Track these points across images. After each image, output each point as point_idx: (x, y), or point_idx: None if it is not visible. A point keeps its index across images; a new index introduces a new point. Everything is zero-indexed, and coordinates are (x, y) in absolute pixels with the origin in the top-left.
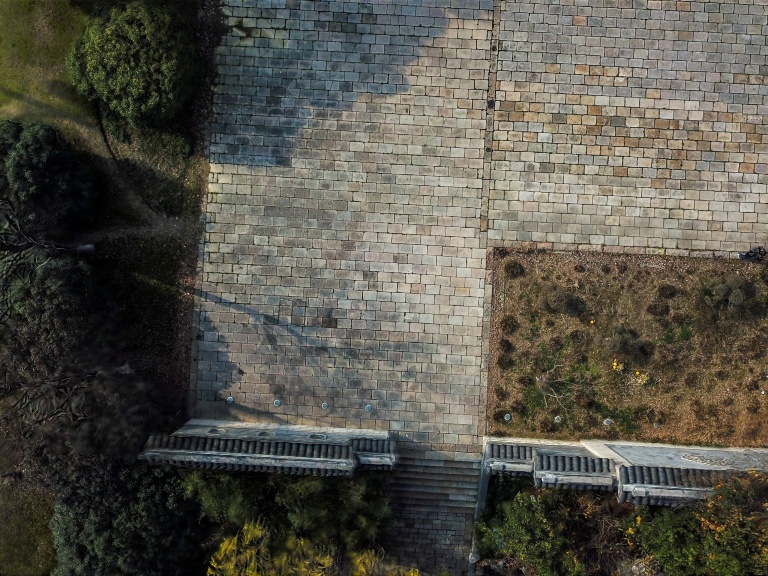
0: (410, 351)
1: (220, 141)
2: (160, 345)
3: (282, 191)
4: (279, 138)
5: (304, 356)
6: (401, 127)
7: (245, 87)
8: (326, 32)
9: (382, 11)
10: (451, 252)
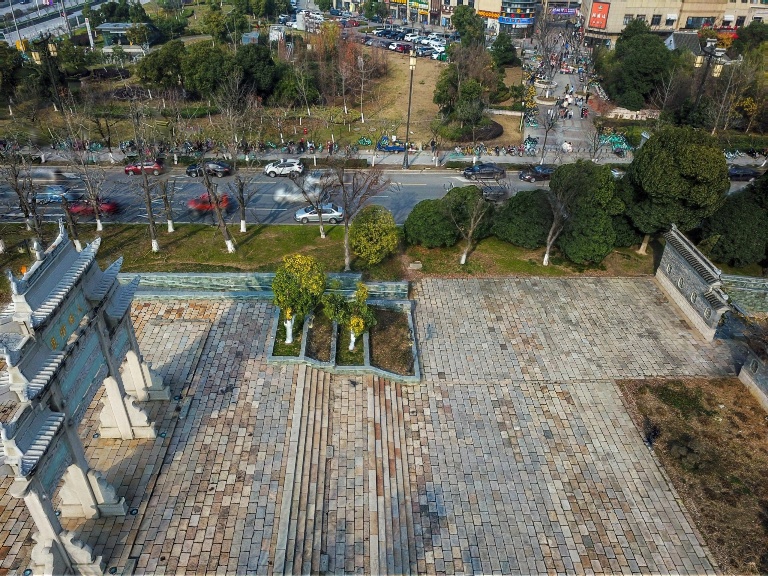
0: None
1: None
2: None
3: None
4: None
5: None
6: None
7: None
8: None
9: None
10: None
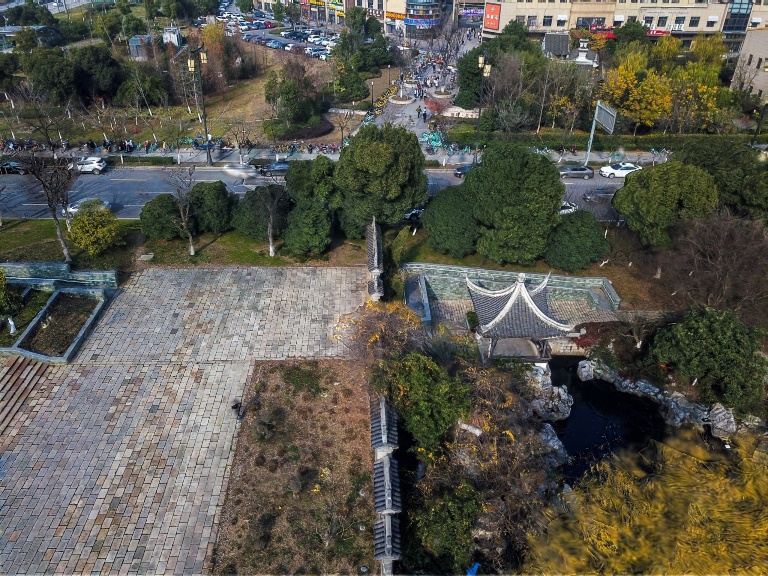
0: None
1: None
2: None
3: None
4: None
5: None
6: None
7: None
8: None
9: None
10: None
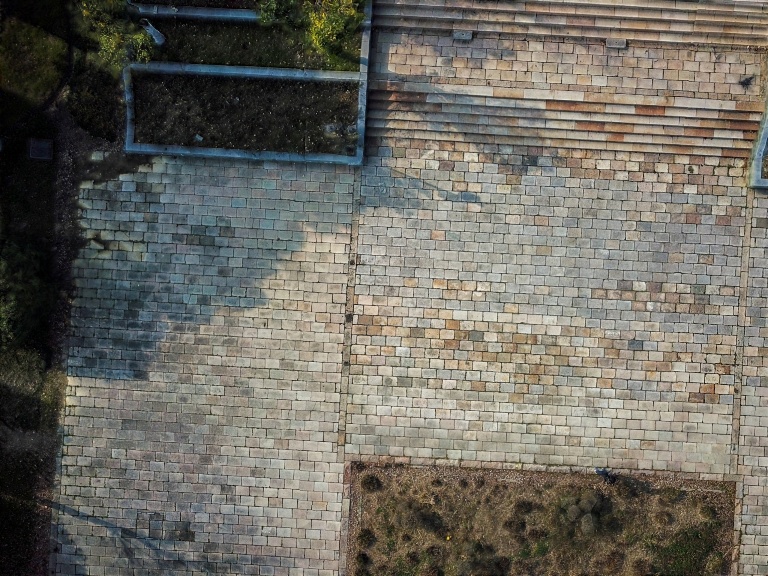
0: (268, 565)
1: (78, 354)
2: (17, 559)
3: (140, 405)
4: (137, 352)
5: (162, 569)
6: (259, 341)
7: (103, 300)
8: (184, 245)
9: (240, 224)
10: (308, 466)
